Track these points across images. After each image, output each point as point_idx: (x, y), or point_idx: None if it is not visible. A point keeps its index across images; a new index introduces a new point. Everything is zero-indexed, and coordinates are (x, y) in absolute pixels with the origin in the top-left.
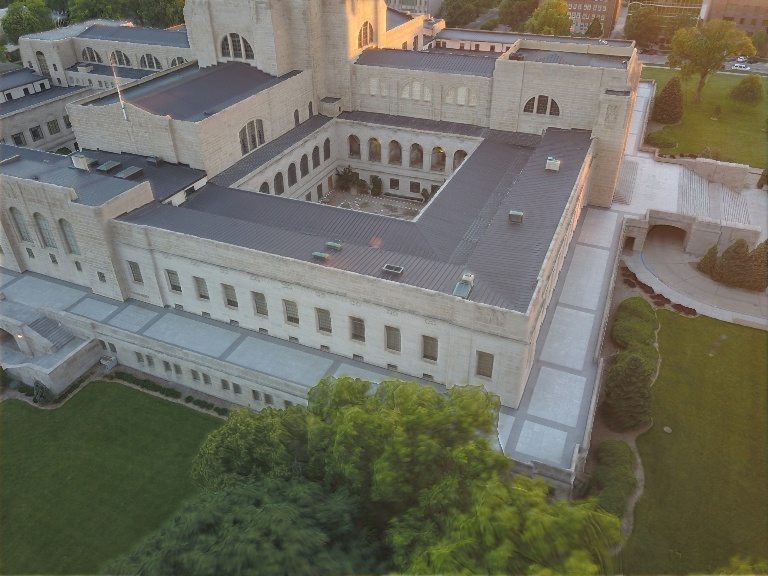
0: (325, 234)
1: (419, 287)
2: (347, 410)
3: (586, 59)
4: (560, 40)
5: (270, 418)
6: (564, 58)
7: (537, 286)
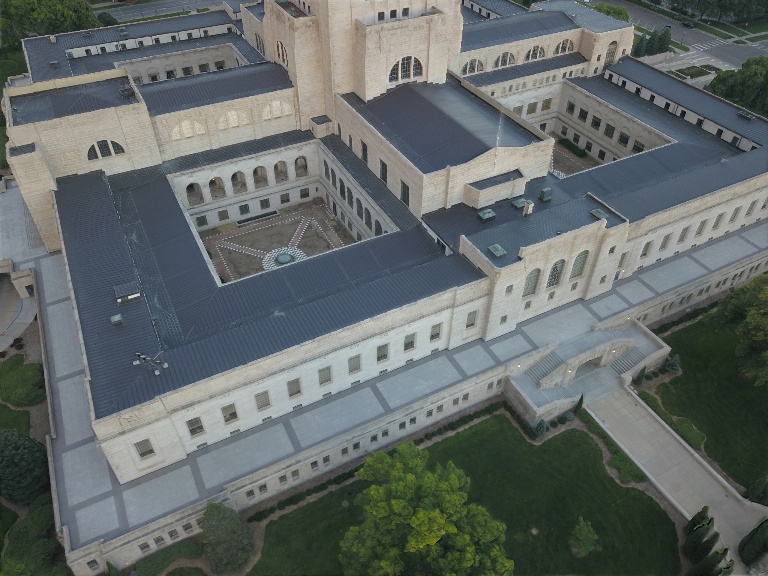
0: (153, 51)
1: (69, 32)
2: (54, 7)
3: (59, 113)
4: (250, 351)
5: (73, 2)
6: (74, 93)
7: (24, 46)
